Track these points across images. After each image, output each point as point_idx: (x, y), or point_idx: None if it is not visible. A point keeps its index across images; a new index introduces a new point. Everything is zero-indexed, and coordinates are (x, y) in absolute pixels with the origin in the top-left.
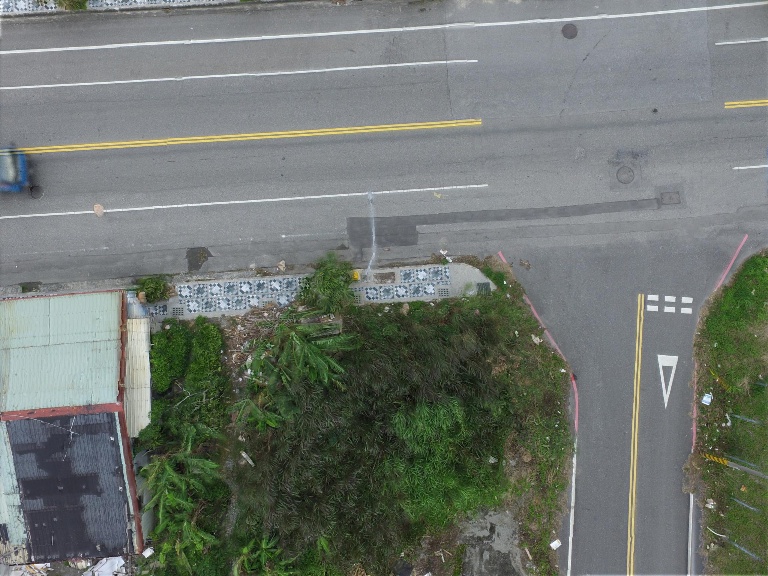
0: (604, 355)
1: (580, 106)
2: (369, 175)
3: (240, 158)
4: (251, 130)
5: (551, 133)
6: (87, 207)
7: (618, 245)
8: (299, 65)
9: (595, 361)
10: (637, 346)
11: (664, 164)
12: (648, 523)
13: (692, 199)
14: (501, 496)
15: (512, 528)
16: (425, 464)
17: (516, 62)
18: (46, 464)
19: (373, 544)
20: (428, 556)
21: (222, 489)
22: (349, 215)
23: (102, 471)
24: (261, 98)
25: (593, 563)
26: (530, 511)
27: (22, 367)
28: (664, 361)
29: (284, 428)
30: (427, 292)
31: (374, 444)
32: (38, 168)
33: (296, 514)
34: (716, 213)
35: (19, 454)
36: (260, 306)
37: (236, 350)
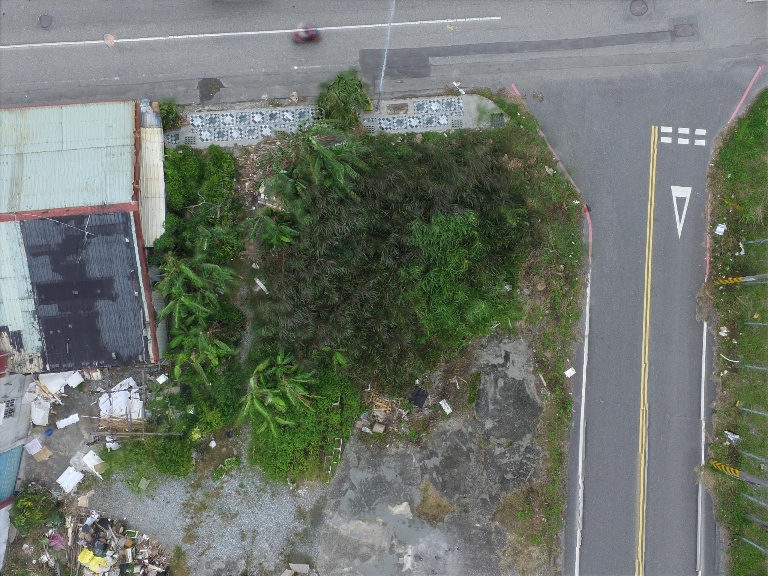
0: (618, 186)
1: None
2: (381, 6)
3: None
4: None
5: None
6: (97, 37)
7: (631, 77)
8: None
9: (609, 192)
10: (651, 177)
11: None
12: (662, 351)
13: (705, 32)
14: (515, 324)
15: (526, 355)
16: (441, 271)
17: None
18: (61, 267)
19: (389, 355)
20: (443, 383)
21: (236, 313)
22: (361, 47)
23: (117, 274)
24: None
25: (607, 390)
26: (544, 338)
27: (35, 171)
28: (678, 192)
29: None
30: (440, 123)
31: (389, 258)
32: None
33: (312, 324)
34: (729, 45)
35: (33, 256)
36: (273, 136)
37: (249, 178)
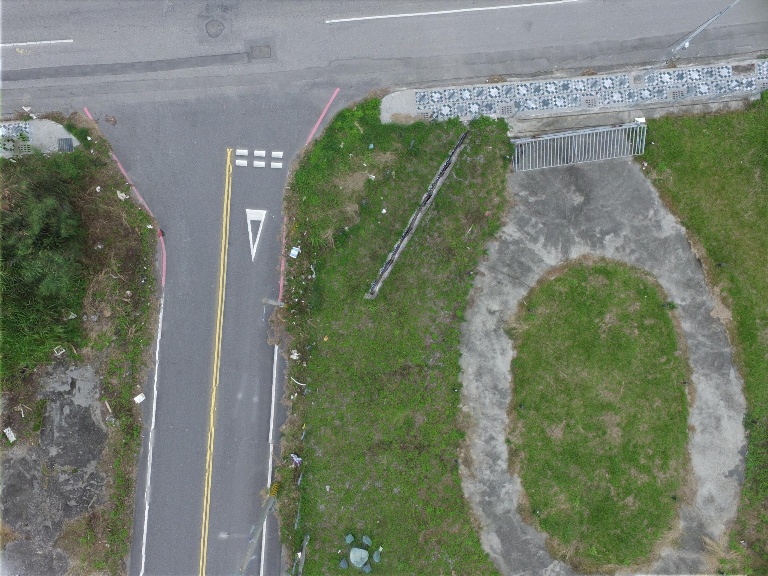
0: (191, 210)
1: None
2: None
3: None
4: None
5: None
6: None
7: (207, 100)
8: None
9: (182, 216)
10: (226, 201)
11: (255, 18)
12: (232, 375)
13: (284, 53)
14: (82, 351)
15: (93, 382)
16: None
17: None
18: None
19: None
20: (8, 412)
21: None
22: None
23: None
24: None
25: (177, 415)
26: (110, 365)
27: None
28: (252, 215)
29: None
30: (7, 148)
31: None
32: None
33: None
34: (307, 67)
35: None
36: None
37: None
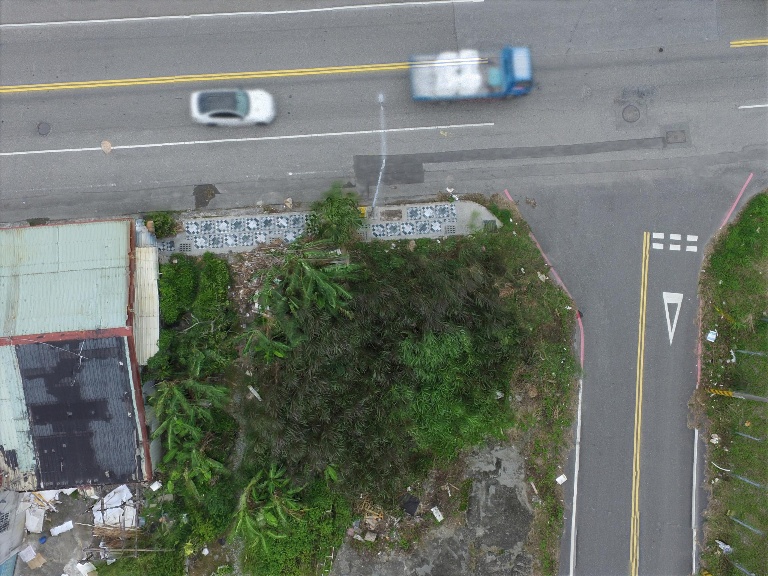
0: (610, 292)
1: (586, 45)
2: (376, 113)
3: (247, 96)
4: (258, 68)
5: (557, 72)
6: (94, 144)
7: (624, 183)
8: (306, 4)
9: (601, 298)
10: (642, 284)
11: (670, 103)
12: (653, 458)
13: (697, 138)
14: (507, 431)
15: (518, 463)
16: (432, 391)
17: (522, 1)
18: (55, 389)
19: (380, 472)
20: (434, 490)
21: (230, 422)
22: (356, 153)
23: (111, 396)
24: (268, 36)
25: (598, 498)
26: (536, 446)
27: (31, 293)
28: (669, 298)
29: (292, 359)
30: (433, 229)
31: (381, 374)
32: (45, 105)
33: (304, 442)
34: (721, 152)
35: (28, 379)
36: (267, 242)
37: (243, 286)
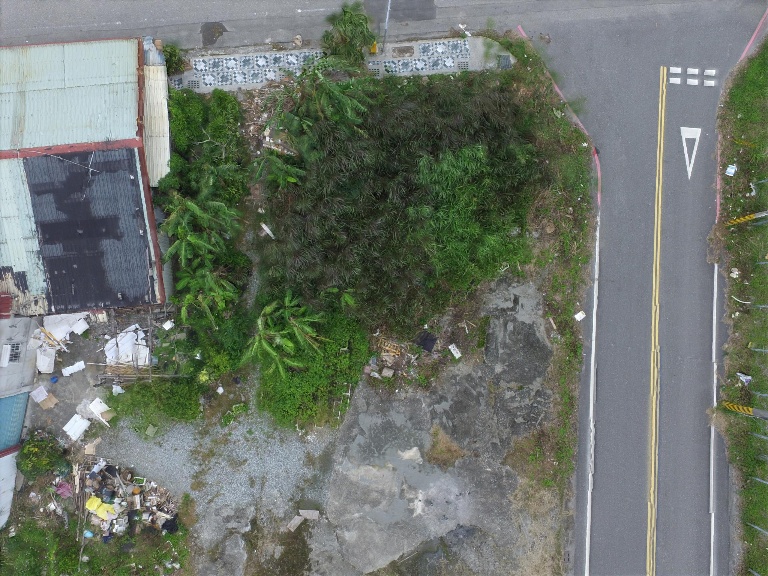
0: (626, 128)
1: None
2: None
3: None
4: None
5: None
6: None
7: (639, 18)
8: None
9: (617, 134)
10: (660, 119)
11: None
12: (673, 293)
13: None
14: (524, 267)
15: (536, 299)
16: (450, 208)
17: None
18: (65, 205)
19: (398, 295)
20: (452, 328)
21: (243, 257)
22: None
23: (122, 212)
24: None
25: (618, 333)
26: (554, 281)
27: (38, 109)
28: (687, 133)
29: (305, 186)
30: (446, 65)
31: None
32: None
33: (320, 264)
34: None
35: (37, 195)
36: (277, 79)
37: (253, 122)
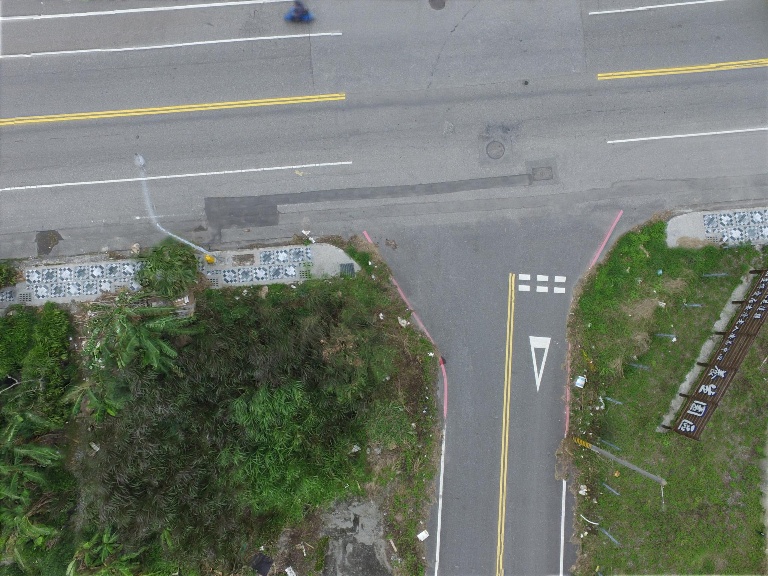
0: (473, 337)
1: (448, 79)
2: (227, 153)
3: (92, 137)
4: (104, 108)
5: (418, 108)
6: None
7: (488, 223)
8: (154, 40)
9: (464, 344)
10: (508, 328)
11: (536, 138)
12: (519, 512)
13: (565, 174)
14: (365, 486)
15: (377, 519)
16: (267, 452)
17: (382, 34)
18: None
19: (216, 537)
20: (289, 549)
21: (68, 482)
22: (207, 195)
23: None
24: (114, 74)
25: (462, 554)
26: (395, 501)
27: None
28: (536, 343)
29: None
30: (288, 274)
31: (219, 432)
32: None
33: (134, 507)
34: (590, 188)
35: None
36: (112, 291)
37: (86, 337)
